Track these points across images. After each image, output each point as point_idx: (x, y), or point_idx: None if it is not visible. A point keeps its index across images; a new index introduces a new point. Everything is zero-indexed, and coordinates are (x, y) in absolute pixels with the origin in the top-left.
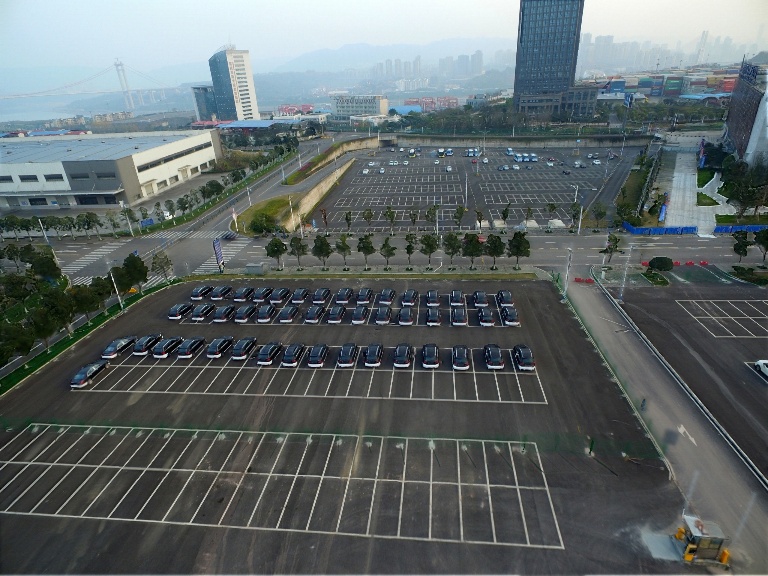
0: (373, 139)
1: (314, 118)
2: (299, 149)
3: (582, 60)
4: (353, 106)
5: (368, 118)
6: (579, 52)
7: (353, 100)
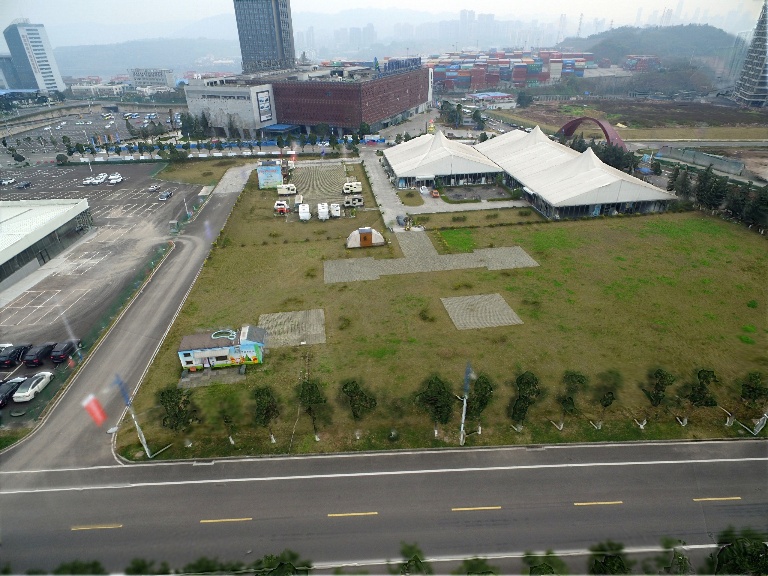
0: (95, 106)
1: (109, 88)
2: (16, 112)
3: (298, 46)
4: (147, 78)
5: (146, 89)
6: (295, 40)
7: (146, 73)
